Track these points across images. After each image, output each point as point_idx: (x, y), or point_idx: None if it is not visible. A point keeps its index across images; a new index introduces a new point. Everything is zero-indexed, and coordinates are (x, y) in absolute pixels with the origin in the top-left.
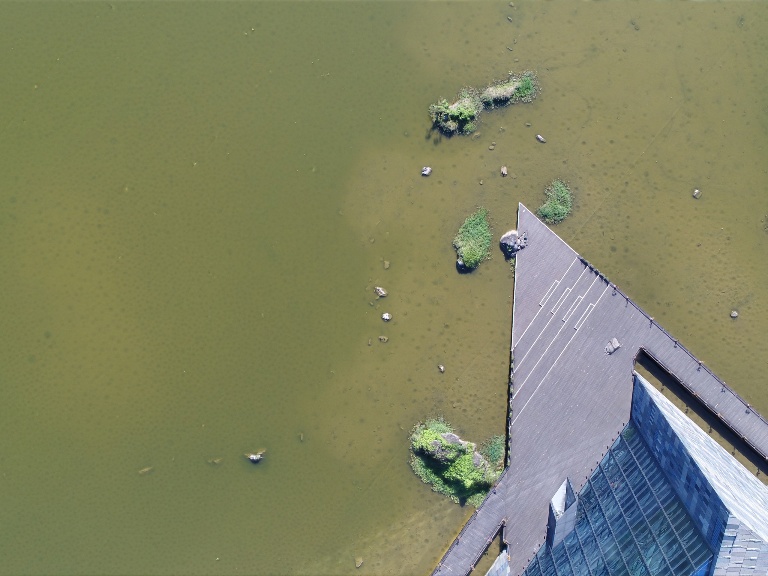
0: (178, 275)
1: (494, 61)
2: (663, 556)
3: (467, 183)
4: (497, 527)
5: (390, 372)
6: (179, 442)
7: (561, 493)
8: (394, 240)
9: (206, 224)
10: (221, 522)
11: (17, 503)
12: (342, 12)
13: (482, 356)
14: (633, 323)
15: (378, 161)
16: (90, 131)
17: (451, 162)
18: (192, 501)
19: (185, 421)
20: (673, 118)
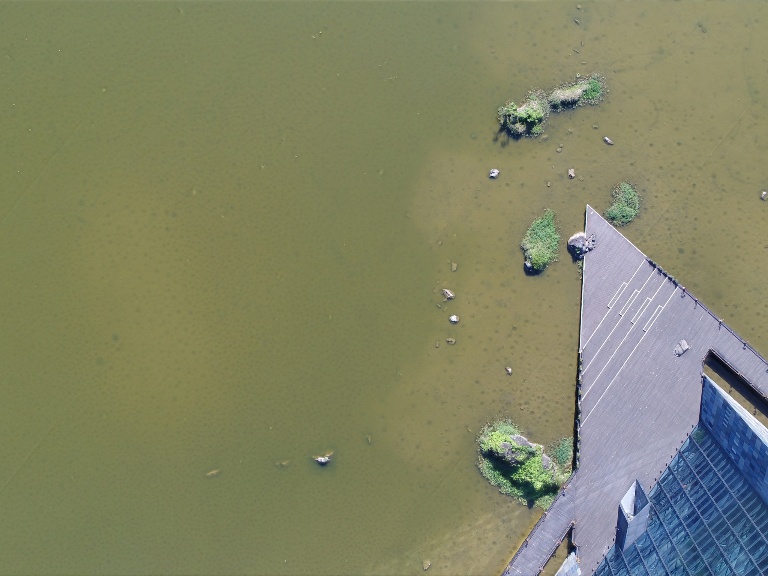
0: (246, 278)
1: (561, 64)
2: (750, 558)
3: (534, 185)
4: (566, 529)
5: (458, 374)
6: (247, 444)
7: (630, 495)
8: (461, 242)
9: (274, 227)
10: (289, 524)
11: (85, 506)
12: (409, 15)
13: (550, 358)
14: (702, 325)
15: (446, 163)
16: (158, 134)
17: (518, 164)
18: (260, 503)
19: (253, 423)
20: (740, 120)
